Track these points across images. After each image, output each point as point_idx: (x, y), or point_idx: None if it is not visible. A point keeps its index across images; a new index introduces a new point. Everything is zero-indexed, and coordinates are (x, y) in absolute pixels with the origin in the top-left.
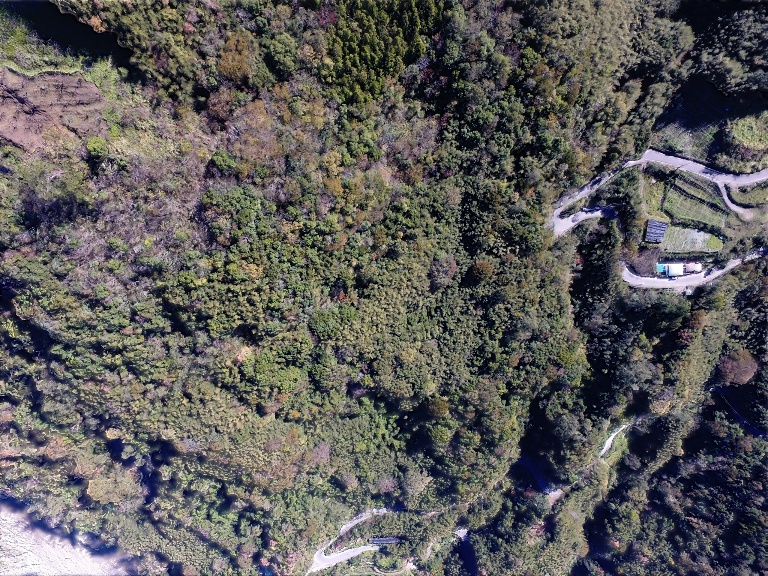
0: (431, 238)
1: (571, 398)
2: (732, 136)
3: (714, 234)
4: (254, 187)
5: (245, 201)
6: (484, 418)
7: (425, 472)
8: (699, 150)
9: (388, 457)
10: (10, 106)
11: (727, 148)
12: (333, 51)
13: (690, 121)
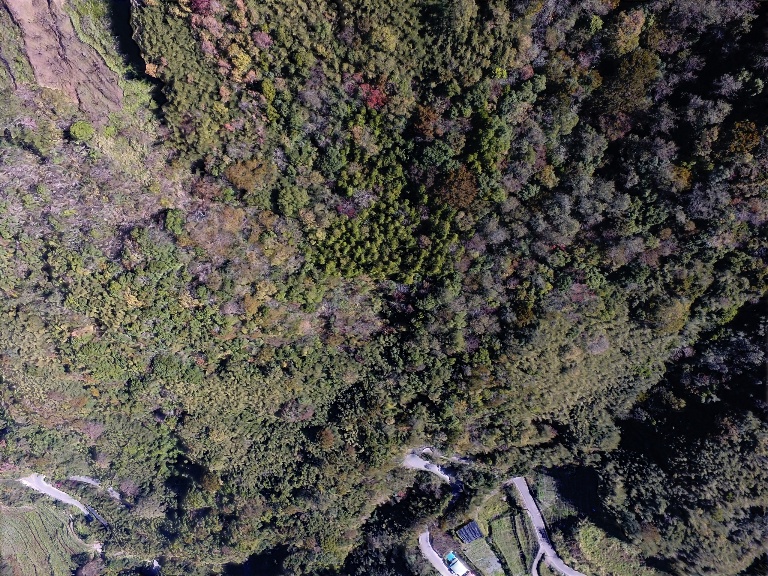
0: (308, 385)
1: (313, 567)
2: (578, 531)
3: (506, 574)
4: (186, 254)
5: (169, 257)
6: (235, 522)
7: (164, 507)
8: (551, 514)
9: (149, 471)
10: (51, 37)
11: (568, 534)
12: (332, 230)
13: (566, 489)
